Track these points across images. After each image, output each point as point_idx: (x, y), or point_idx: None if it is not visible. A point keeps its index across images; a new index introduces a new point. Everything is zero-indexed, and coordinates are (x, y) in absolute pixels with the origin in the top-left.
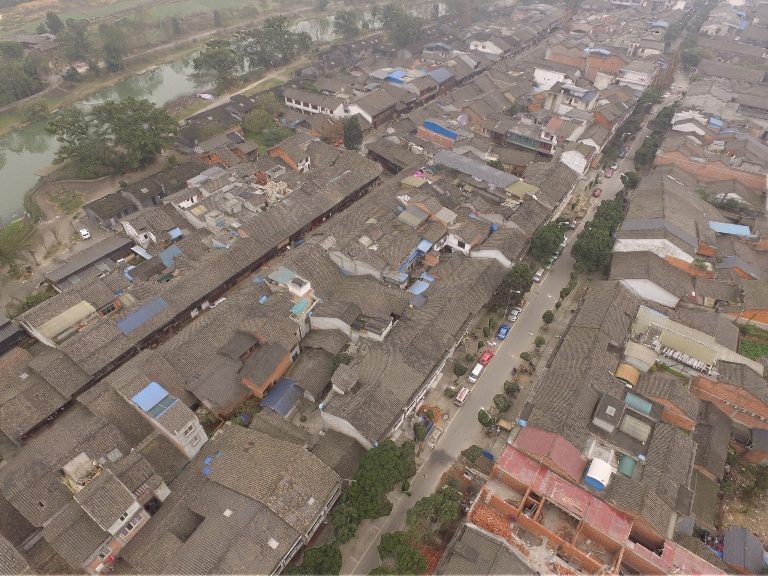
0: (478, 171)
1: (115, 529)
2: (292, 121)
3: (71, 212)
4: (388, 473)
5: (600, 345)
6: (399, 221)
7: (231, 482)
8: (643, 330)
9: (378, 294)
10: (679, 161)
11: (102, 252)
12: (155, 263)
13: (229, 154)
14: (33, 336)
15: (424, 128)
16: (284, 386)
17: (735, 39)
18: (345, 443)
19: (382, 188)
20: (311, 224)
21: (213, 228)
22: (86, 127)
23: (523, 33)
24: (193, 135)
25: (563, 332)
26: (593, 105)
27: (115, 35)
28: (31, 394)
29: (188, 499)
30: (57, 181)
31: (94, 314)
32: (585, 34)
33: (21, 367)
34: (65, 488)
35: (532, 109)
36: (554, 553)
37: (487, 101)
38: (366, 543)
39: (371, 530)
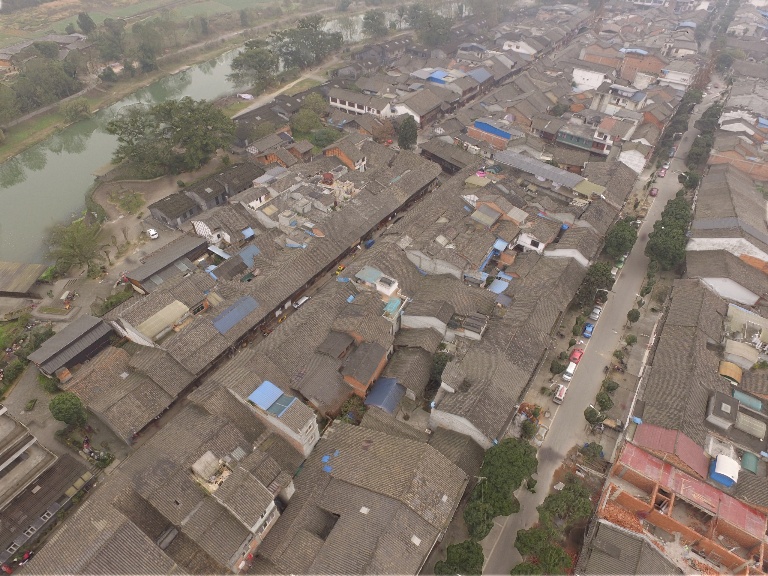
0: (542, 171)
1: (256, 527)
2: (339, 121)
3: (134, 212)
4: (518, 470)
5: (700, 343)
6: (471, 220)
7: (359, 480)
8: (739, 328)
9: (463, 293)
10: (734, 161)
11: (180, 252)
12: (237, 262)
13: (286, 154)
14: (123, 336)
15: (475, 128)
16: (386, 385)
17: (761, 39)
18: (460, 441)
19: (447, 188)
20: (379, 224)
21: (285, 228)
22: (143, 127)
23: (553, 33)
24: (244, 135)
25: (658, 330)
26: (642, 105)
27: (151, 35)
28: (140, 393)
29: (316, 497)
30: (114, 181)
31: (187, 313)
32: (616, 34)
33: (120, 366)
34: (197, 486)
35: (574, 109)
36: (689, 549)
37: (531, 101)
38: (492, 540)
39: (494, 527)
